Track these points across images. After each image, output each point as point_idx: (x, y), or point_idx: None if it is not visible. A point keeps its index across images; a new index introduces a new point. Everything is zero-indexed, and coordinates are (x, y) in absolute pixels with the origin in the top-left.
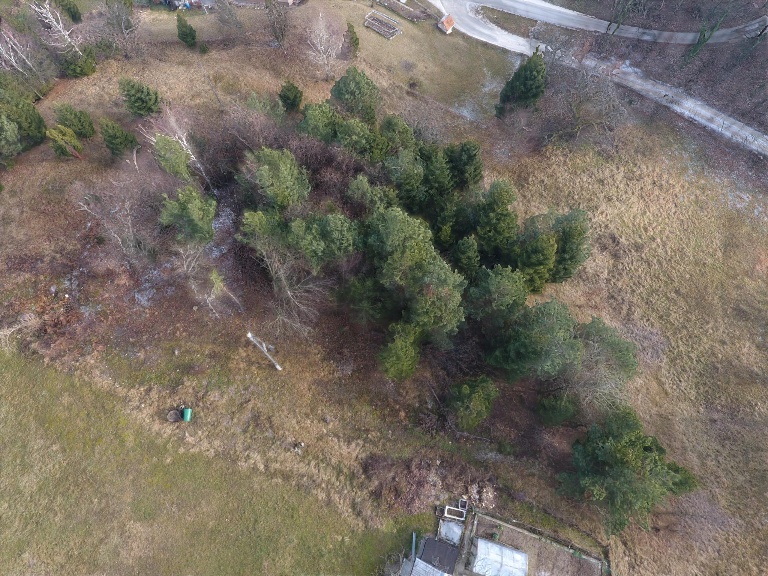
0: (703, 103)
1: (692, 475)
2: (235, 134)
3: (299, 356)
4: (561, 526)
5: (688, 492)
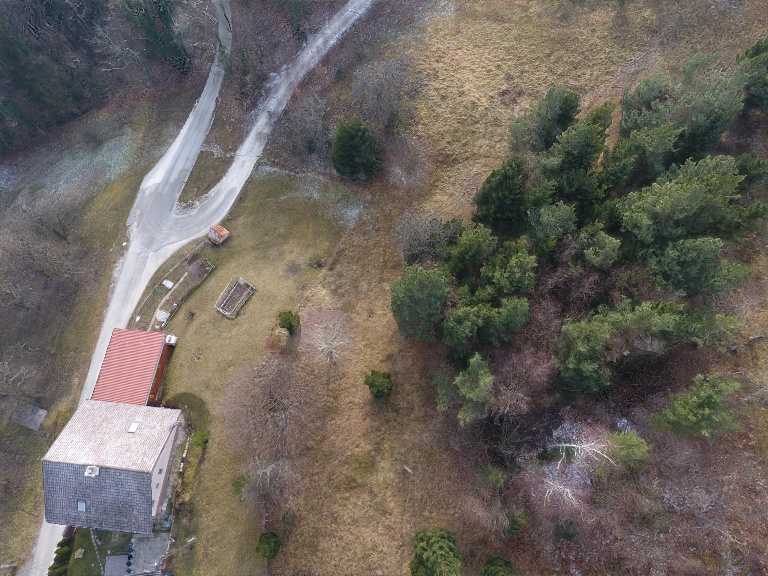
0: (328, 22)
1: (759, 41)
2: None
3: None
4: None
5: None
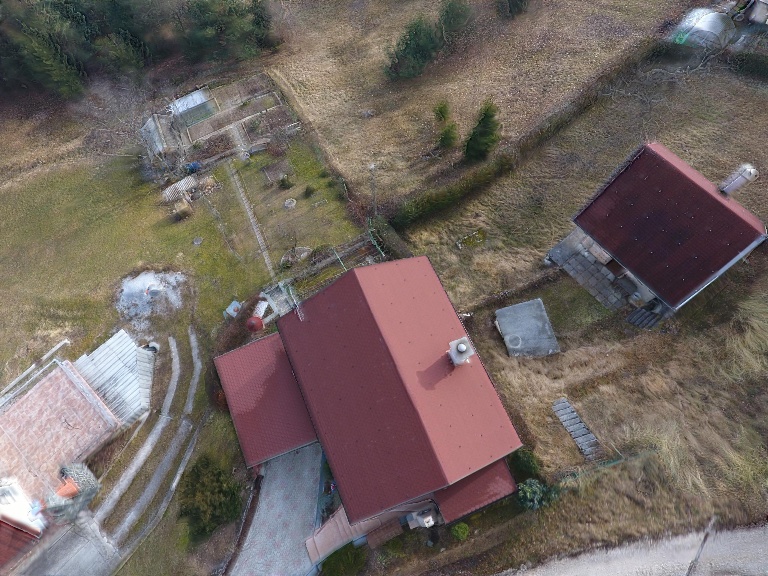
0: None
1: None
2: None
3: (7, 127)
4: (235, 77)
5: (277, 2)
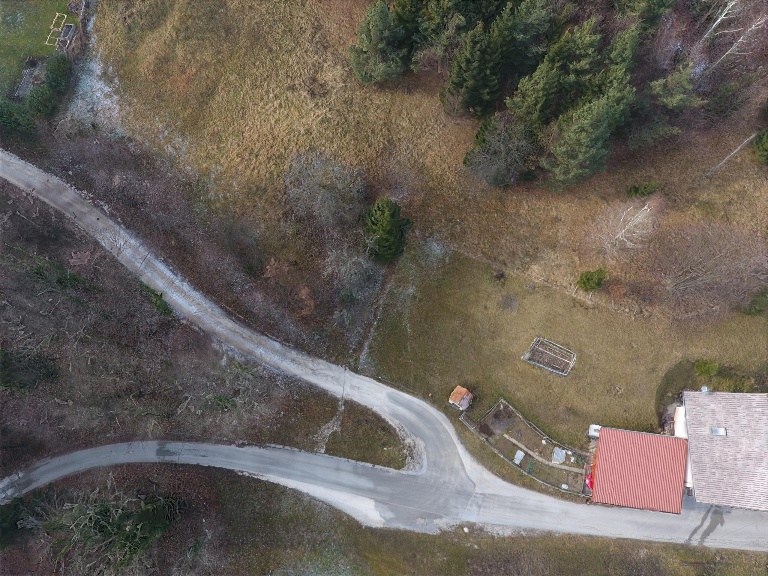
0: None
1: None
2: (688, 81)
3: None
4: None
5: None
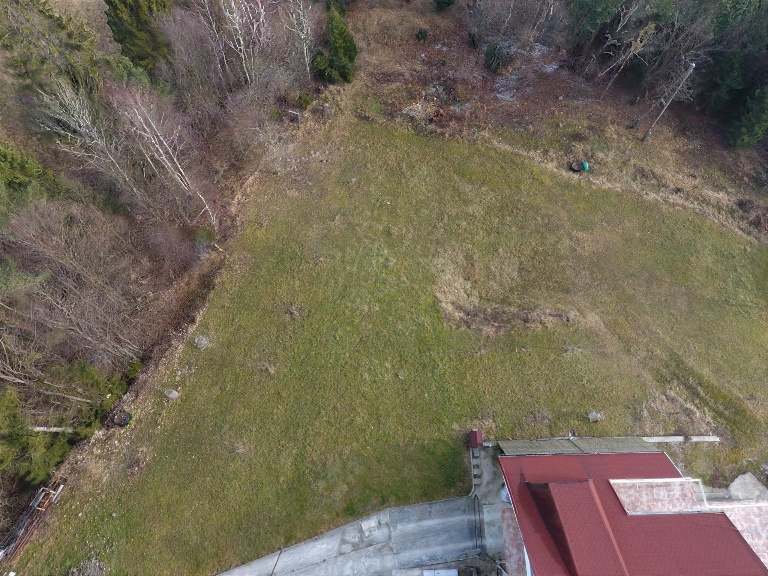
0: None
1: None
2: None
3: (656, 133)
4: None
5: None
